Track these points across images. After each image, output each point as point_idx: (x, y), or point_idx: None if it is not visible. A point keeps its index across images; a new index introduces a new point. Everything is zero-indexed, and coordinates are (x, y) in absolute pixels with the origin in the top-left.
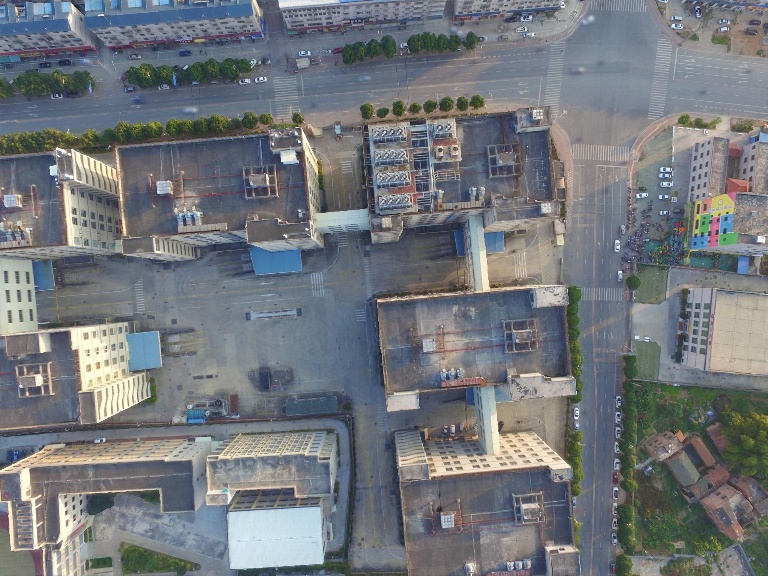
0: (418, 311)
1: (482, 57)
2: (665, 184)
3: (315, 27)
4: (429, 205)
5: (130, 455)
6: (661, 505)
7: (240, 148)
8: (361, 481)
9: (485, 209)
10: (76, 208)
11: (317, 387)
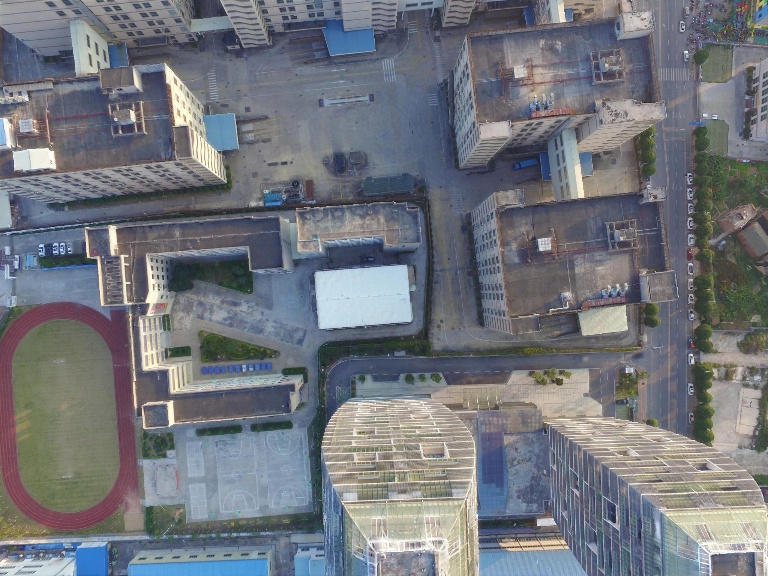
0: (506, 45)
1: None
2: None
3: None
4: None
5: None
6: (736, 278)
7: None
8: (438, 263)
9: None
10: None
11: (392, 171)
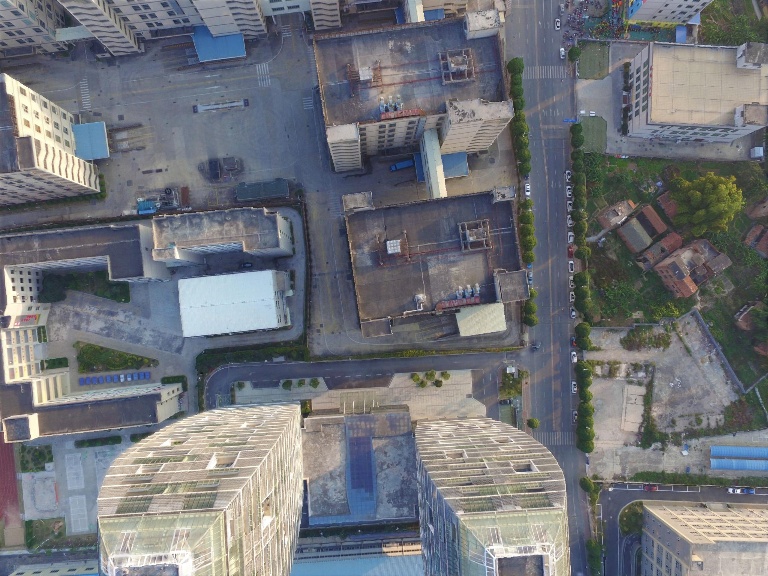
0: (354, 47)
1: None
2: None
3: None
4: None
5: None
6: (617, 274)
7: None
8: (317, 267)
9: None
10: None
11: (268, 176)
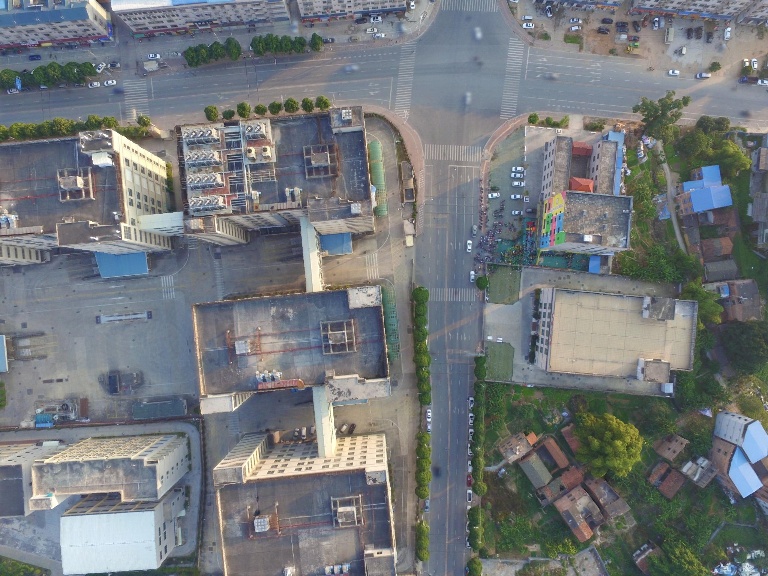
0: (235, 313)
1: (332, 58)
2: (516, 184)
3: (161, 30)
4: (244, 206)
5: None
6: (514, 508)
7: (56, 151)
8: (212, 485)
9: (303, 210)
10: None
11: (168, 390)
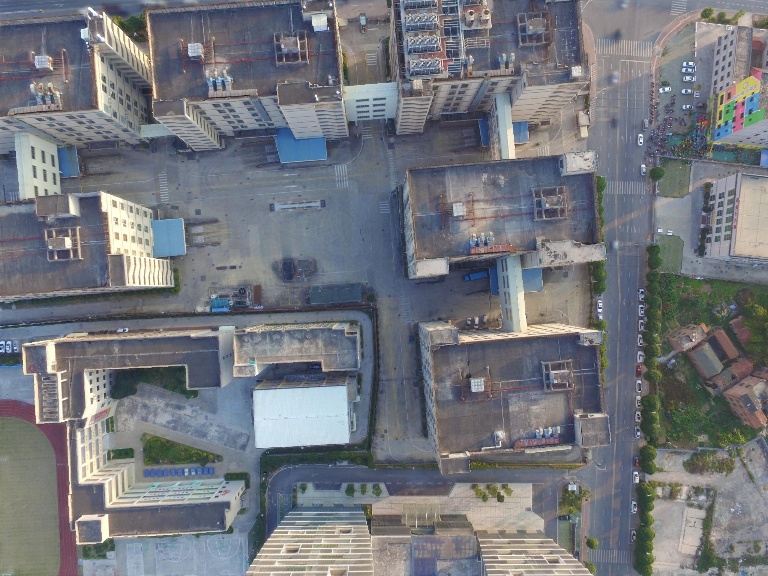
0: (448, 179)
1: None
2: (688, 78)
3: None
4: (459, 72)
5: (155, 335)
6: (684, 397)
7: (271, 15)
8: (384, 373)
9: (514, 78)
10: (105, 77)
11: (341, 278)
